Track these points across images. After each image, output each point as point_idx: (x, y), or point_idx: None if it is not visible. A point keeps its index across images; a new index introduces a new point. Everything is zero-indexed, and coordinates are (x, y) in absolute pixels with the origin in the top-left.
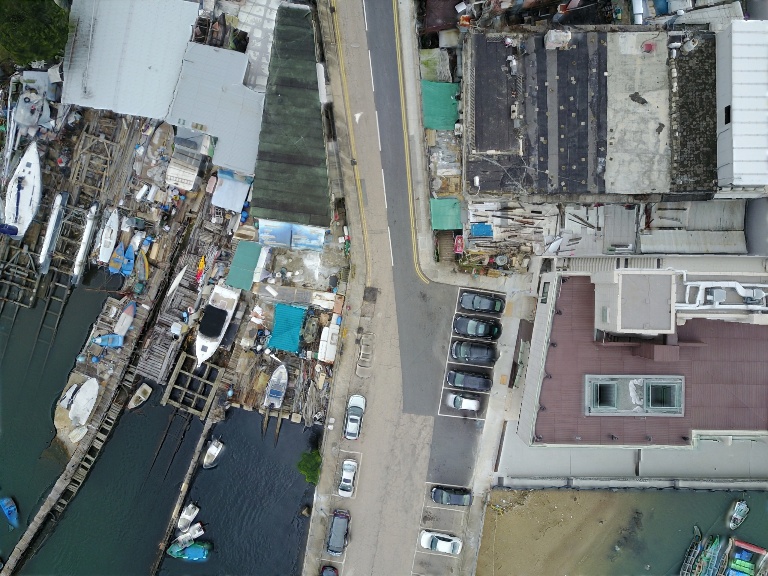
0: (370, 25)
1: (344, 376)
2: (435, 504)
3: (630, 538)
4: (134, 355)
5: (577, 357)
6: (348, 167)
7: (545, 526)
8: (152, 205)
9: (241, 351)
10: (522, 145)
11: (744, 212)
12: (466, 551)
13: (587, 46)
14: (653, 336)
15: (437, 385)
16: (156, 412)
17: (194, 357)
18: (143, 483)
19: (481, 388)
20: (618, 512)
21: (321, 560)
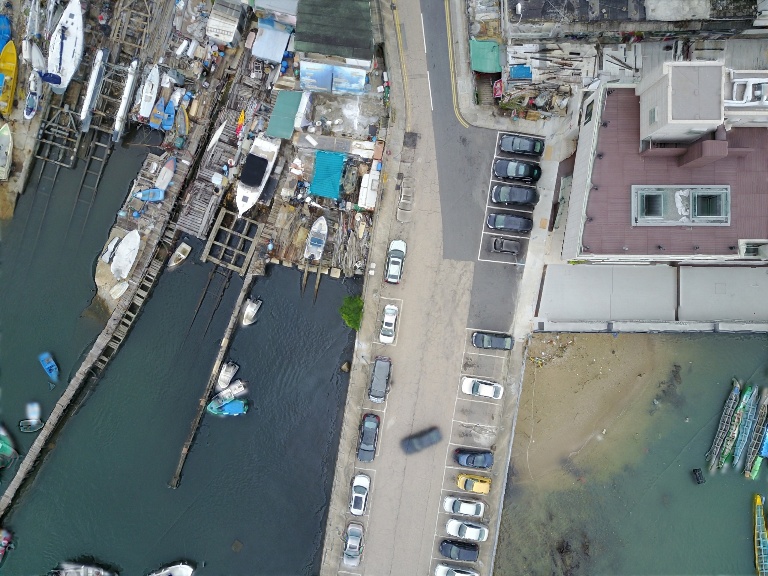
0: None
1: (384, 222)
2: (476, 350)
3: (669, 391)
4: (174, 212)
5: (623, 169)
6: (388, 11)
7: (584, 379)
8: (192, 61)
9: (280, 206)
10: None
11: None
12: (507, 397)
13: None
14: (701, 135)
15: (477, 230)
16: (196, 270)
17: (234, 213)
18: (183, 341)
19: (522, 228)
20: (656, 365)
21: (362, 409)
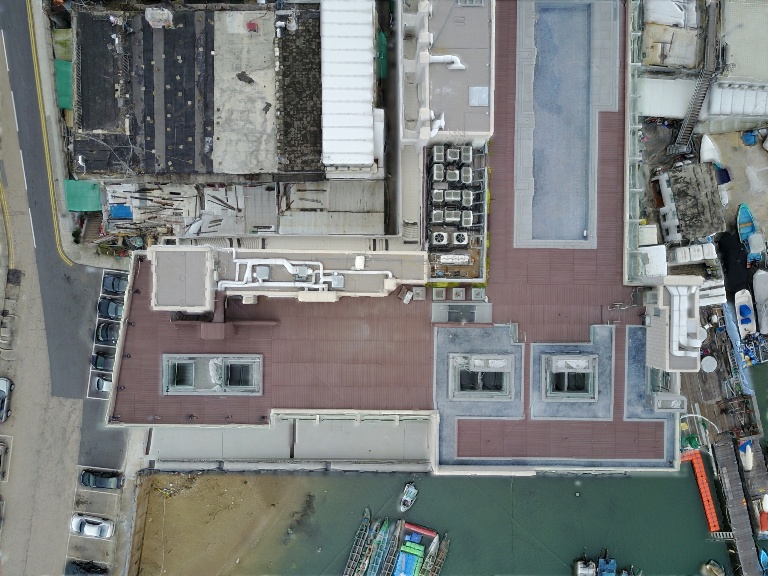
0: (2, 4)
1: None
2: (87, 487)
3: (302, 521)
4: None
5: (157, 336)
6: None
7: (215, 509)
8: None
9: None
10: (129, 124)
11: (384, 193)
12: (120, 534)
13: (194, 25)
14: (207, 314)
15: (85, 368)
16: None
17: None
18: None
19: None
20: (290, 495)
21: None
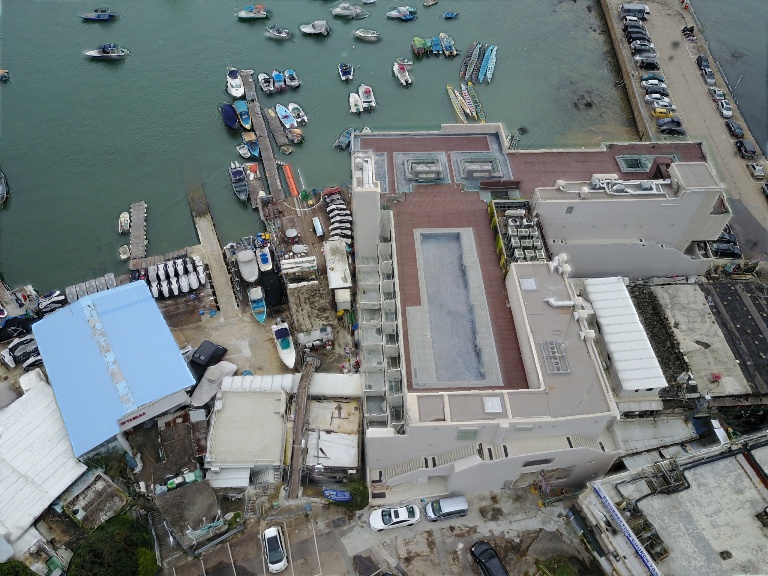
0: None
1: None
2: None
3: None
4: None
5: None
6: None
7: None
8: None
9: None
10: None
11: None
12: None
13: (764, 382)
14: None
15: None
16: None
17: None
18: None
19: None
20: None
21: None
